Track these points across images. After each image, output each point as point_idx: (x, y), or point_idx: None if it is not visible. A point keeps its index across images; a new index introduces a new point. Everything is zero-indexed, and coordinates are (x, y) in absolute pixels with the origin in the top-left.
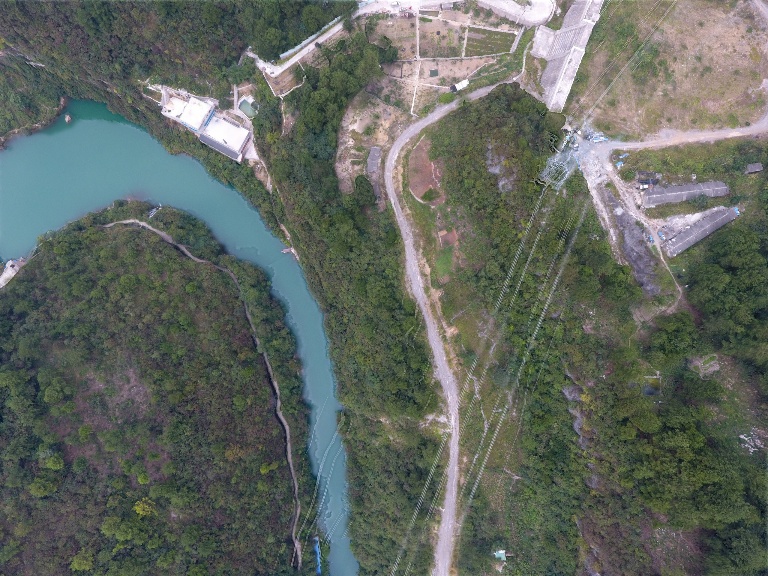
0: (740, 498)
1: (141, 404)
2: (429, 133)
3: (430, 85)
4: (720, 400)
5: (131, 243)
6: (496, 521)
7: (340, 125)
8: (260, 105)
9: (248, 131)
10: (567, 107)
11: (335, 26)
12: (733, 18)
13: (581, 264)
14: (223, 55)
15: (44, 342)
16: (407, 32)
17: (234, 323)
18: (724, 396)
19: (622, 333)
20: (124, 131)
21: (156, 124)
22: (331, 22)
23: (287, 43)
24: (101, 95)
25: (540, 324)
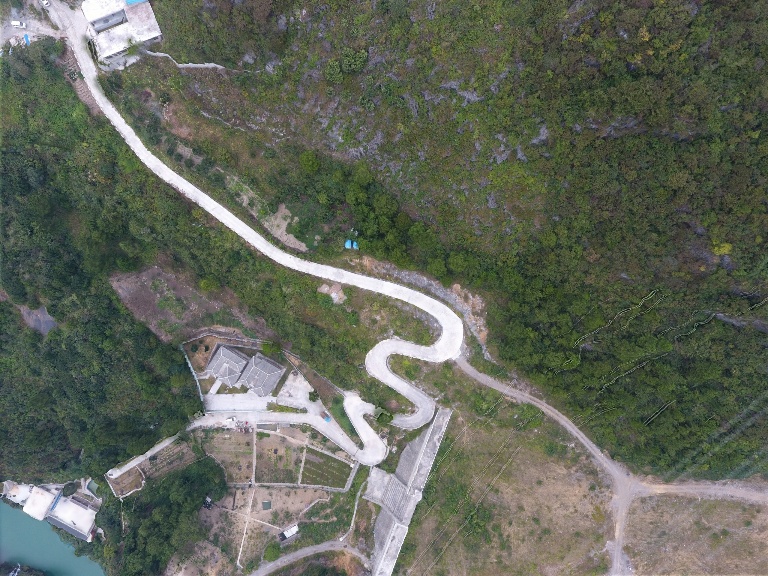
0: None
1: None
2: None
3: (261, 522)
4: None
5: None
6: None
7: (164, 574)
8: None
9: None
10: None
11: None
12: (575, 474)
13: None
14: (58, 461)
15: None
16: (244, 447)
17: None
18: None
19: None
20: None
21: None
22: (165, 436)
23: None
24: None
25: None
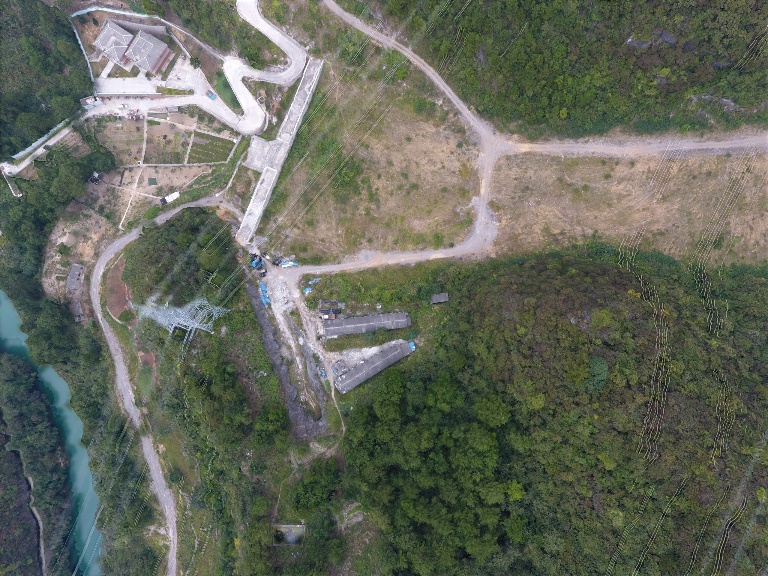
0: None
1: None
2: (127, 252)
3: (146, 195)
4: (355, 554)
5: None
6: None
7: (49, 238)
8: None
9: None
10: (264, 227)
11: (66, 127)
12: (443, 132)
13: (222, 411)
14: None
15: None
16: (135, 135)
17: None
18: (359, 550)
19: (274, 477)
20: None
21: None
22: (59, 124)
23: (15, 146)
24: None
25: (213, 458)
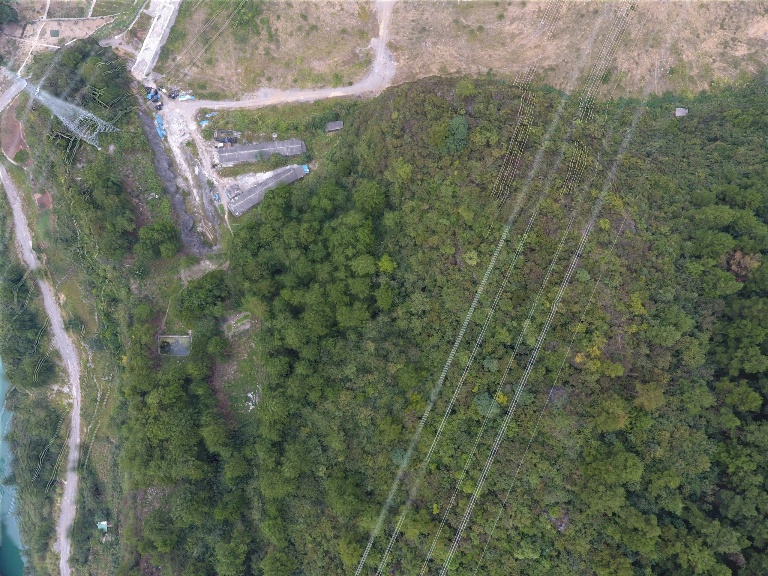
0: (187, 453)
1: None
2: None
3: (48, 45)
4: (241, 358)
5: None
6: (102, 492)
7: None
8: None
9: None
10: (162, 65)
11: None
12: None
13: None
14: None
15: None
16: None
17: None
18: (245, 354)
19: (163, 292)
20: None
21: None
22: None
23: None
24: None
25: None
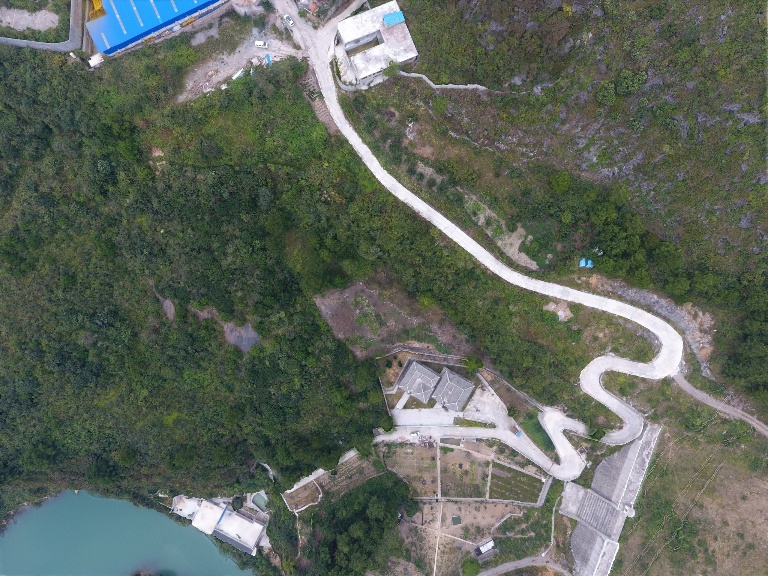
0: None
1: None
2: None
3: (453, 537)
4: None
5: None
6: None
7: None
8: (274, 520)
9: (262, 527)
10: None
11: (351, 450)
12: None
13: None
14: (235, 476)
15: None
16: (427, 462)
17: None
18: None
19: None
20: (135, 509)
21: None
22: (347, 451)
23: None
24: None
25: None
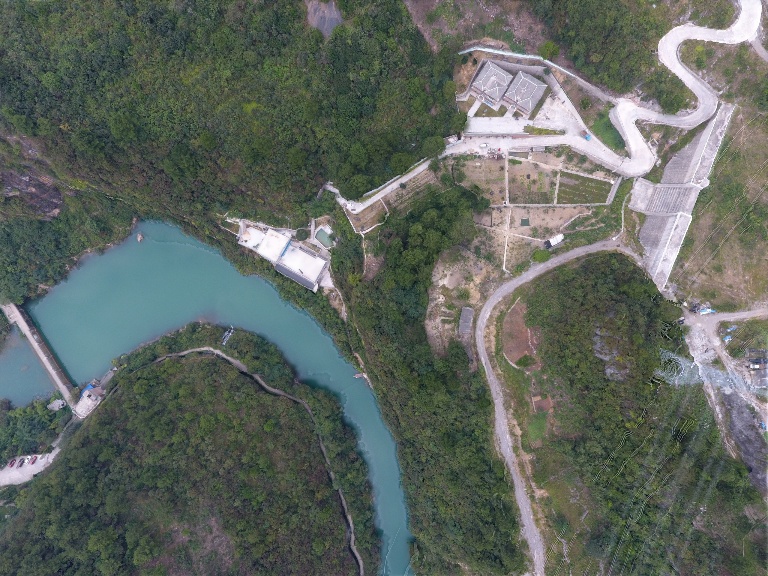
0: None
1: (224, 556)
2: (525, 296)
3: (522, 236)
4: None
5: (209, 379)
6: None
7: None
8: (340, 242)
9: (325, 261)
10: (671, 273)
11: (420, 165)
12: None
13: (697, 467)
14: (304, 192)
15: (130, 496)
16: (495, 174)
17: (310, 460)
18: None
19: (735, 533)
20: (197, 254)
21: (231, 251)
22: (417, 163)
23: (371, 184)
24: (176, 221)
25: (643, 509)
